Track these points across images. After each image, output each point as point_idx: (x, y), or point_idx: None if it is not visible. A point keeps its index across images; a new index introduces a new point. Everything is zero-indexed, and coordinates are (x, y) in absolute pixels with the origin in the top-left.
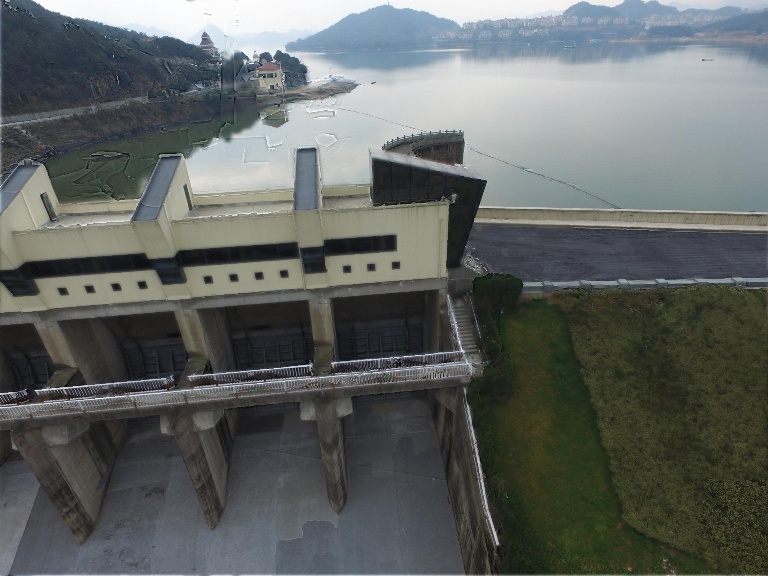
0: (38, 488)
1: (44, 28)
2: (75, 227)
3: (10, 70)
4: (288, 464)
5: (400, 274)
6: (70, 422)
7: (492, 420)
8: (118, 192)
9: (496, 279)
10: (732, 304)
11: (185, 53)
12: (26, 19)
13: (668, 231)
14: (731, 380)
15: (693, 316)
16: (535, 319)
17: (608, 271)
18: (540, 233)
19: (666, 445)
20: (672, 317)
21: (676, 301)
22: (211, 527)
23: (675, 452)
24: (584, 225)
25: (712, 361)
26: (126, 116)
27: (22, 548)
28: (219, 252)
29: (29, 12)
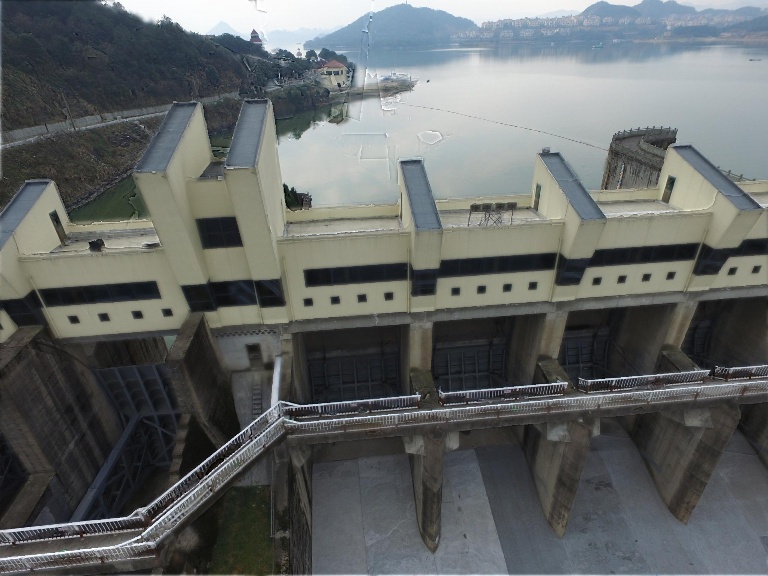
0: (482, 480)
1: (143, 24)
2: (648, 216)
3: (120, 65)
4: (721, 459)
5: None
6: (628, 413)
7: None
8: None
9: None
10: None
11: (246, 50)
12: None
13: None
14: None
15: None
16: None
17: None
18: None
19: None
20: None
21: None
22: (686, 522)
23: None
24: None
25: None
26: (223, 112)
27: (504, 540)
28: (758, 243)
29: (124, 8)
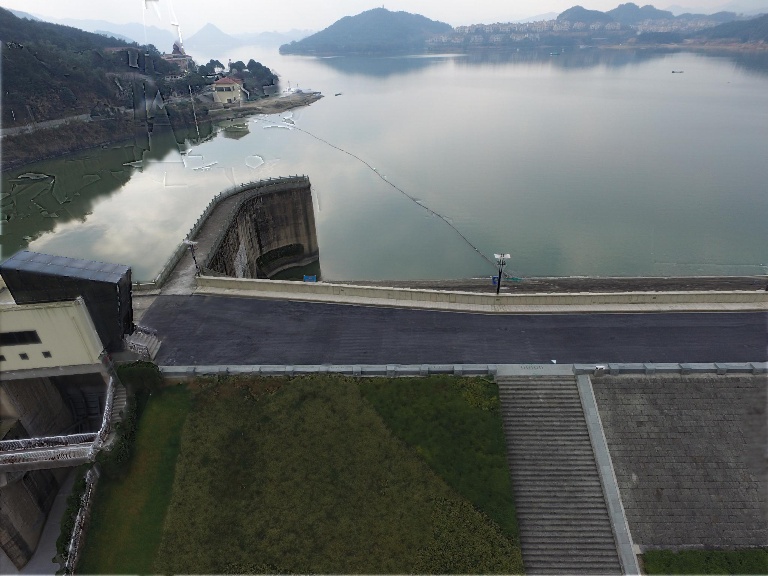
0: None
1: None
2: None
3: None
4: None
5: (55, 361)
6: None
7: (106, 498)
8: (50, 211)
9: (133, 368)
10: (333, 394)
11: None
12: None
13: (368, 306)
14: (297, 468)
15: (294, 405)
16: (170, 403)
17: (266, 354)
18: (254, 307)
19: (211, 530)
20: (276, 406)
21: (287, 390)
22: None
23: (215, 537)
24: (299, 298)
25: (291, 449)
26: (65, 135)
27: None
28: None
29: None
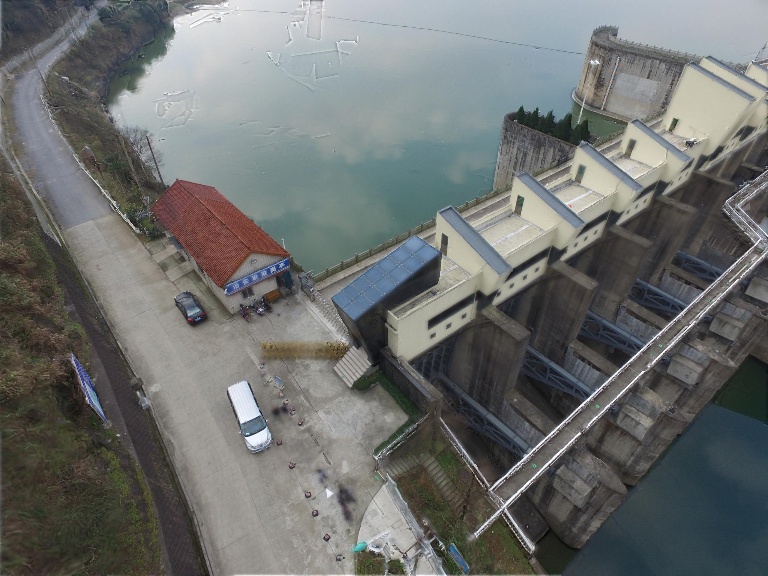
0: None
1: None
2: None
3: None
4: None
5: None
6: None
7: None
8: None
9: None
10: None
11: None
12: None
13: None
14: None
15: None
16: None
17: None
18: None
19: None
20: None
21: None
22: None
23: None
24: None
25: None
26: (104, 45)
27: None
28: None
29: None
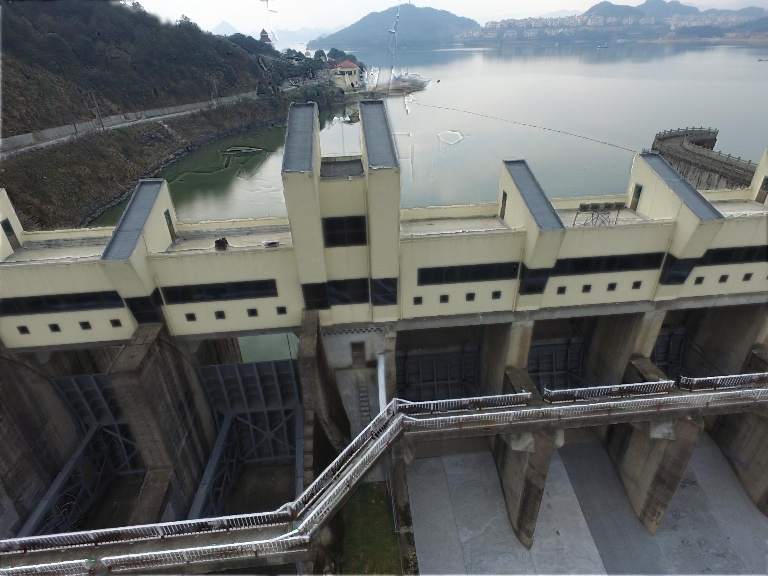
0: (568, 478)
1: (163, 23)
2: (758, 216)
3: (142, 65)
4: None
5: None
6: (735, 411)
7: None
8: None
9: None
10: None
11: (258, 50)
12: (142, 14)
13: None
14: None
15: None
16: None
17: None
18: None
19: None
20: None
21: None
22: None
23: None
24: None
25: None
26: (242, 112)
27: (597, 537)
28: None
29: (143, 7)
